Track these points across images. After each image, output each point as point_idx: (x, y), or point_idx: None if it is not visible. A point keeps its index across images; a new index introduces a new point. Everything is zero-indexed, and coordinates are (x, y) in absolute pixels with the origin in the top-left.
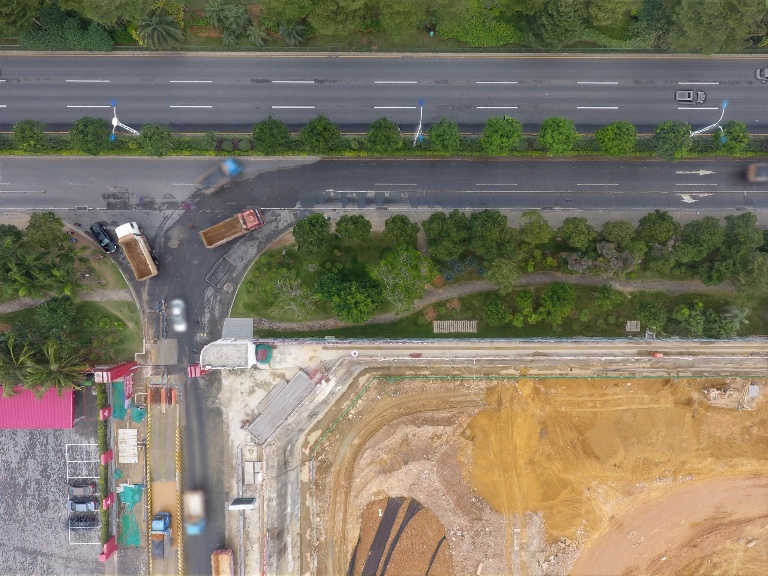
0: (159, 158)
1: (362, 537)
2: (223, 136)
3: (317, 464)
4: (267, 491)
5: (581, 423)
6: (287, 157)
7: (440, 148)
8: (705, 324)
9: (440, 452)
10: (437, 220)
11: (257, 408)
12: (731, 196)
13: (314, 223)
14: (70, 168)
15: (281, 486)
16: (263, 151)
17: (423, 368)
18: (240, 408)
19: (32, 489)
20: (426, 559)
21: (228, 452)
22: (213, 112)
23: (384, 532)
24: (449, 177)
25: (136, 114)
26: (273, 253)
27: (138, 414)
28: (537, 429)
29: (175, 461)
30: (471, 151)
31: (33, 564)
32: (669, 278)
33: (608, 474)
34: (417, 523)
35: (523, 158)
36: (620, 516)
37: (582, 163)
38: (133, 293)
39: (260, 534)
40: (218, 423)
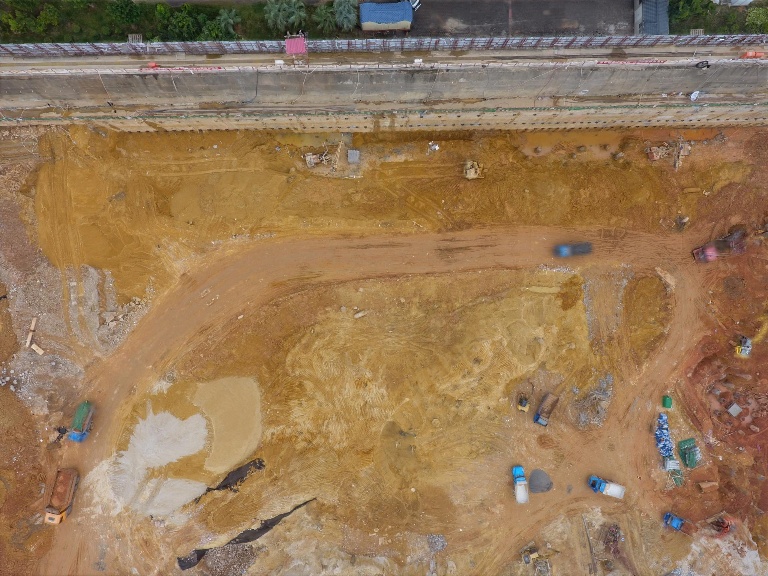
0: None
1: None
2: None
3: None
4: None
5: (166, 187)
6: None
7: None
8: None
9: None
10: None
11: None
12: None
13: None
14: None
15: None
16: None
17: None
18: None
19: None
20: None
21: None
22: None
23: None
24: None
25: None
26: None
27: None
28: (106, 187)
29: None
30: None
31: None
32: None
33: (179, 230)
34: None
35: None
36: (192, 273)
37: None
38: None
39: None
40: None
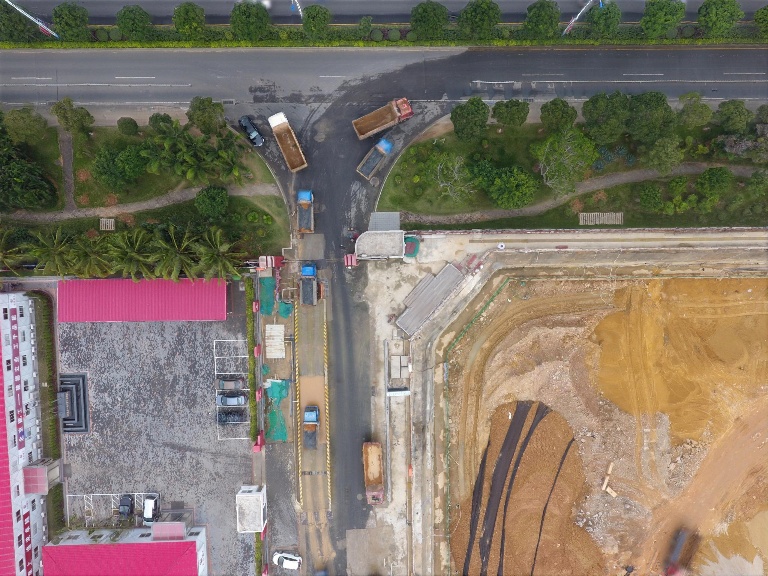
0: (305, 50)
1: (492, 440)
2: (372, 25)
3: (449, 367)
4: (413, 385)
5: (702, 329)
6: (434, 48)
7: (601, 28)
8: None
9: (572, 353)
10: (602, 99)
11: (403, 302)
12: None
13: (476, 105)
14: (216, 61)
15: (424, 382)
16: (422, 33)
17: (556, 269)
18: (386, 303)
19: (181, 385)
20: (556, 460)
21: (374, 347)
22: (359, 2)
23: (514, 434)
24: (596, 67)
25: (282, 5)
26: (420, 145)
27: (285, 310)
28: (662, 333)
29: (323, 355)
30: (620, 39)
31: (182, 459)
32: None
33: (733, 376)
34: (546, 425)
35: (671, 47)
36: (745, 418)
37: (729, 52)
38: (280, 188)
39: (406, 428)
40: (364, 318)
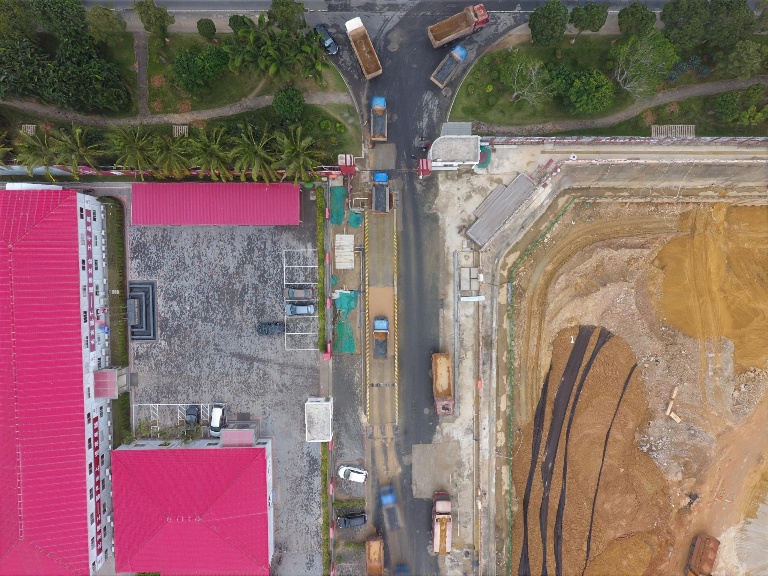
0: None
1: (554, 364)
2: None
3: (512, 288)
4: None
5: (764, 259)
6: None
7: None
8: None
9: (637, 275)
10: None
11: (474, 213)
12: None
13: None
14: None
15: (492, 296)
16: None
17: (622, 189)
18: (457, 214)
19: (249, 294)
20: (619, 385)
21: (444, 258)
22: None
23: (577, 358)
24: None
25: None
26: None
27: (355, 220)
28: (725, 260)
29: (394, 265)
30: None
31: (249, 370)
32: None
33: None
34: (609, 350)
35: None
36: None
37: None
38: (352, 97)
39: (474, 341)
40: (434, 229)
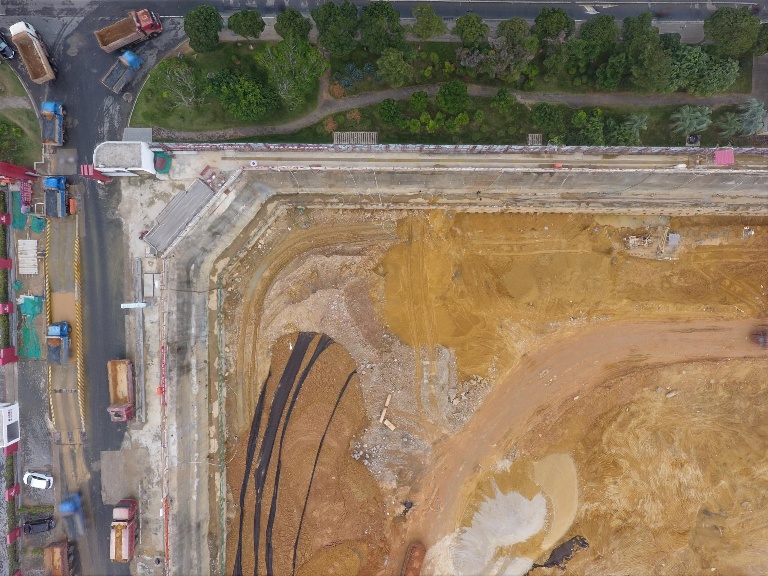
0: None
1: (272, 370)
2: None
3: (226, 294)
4: (167, 304)
5: (498, 267)
6: None
7: None
8: (606, 136)
9: (349, 282)
10: (324, 6)
11: (156, 219)
12: (635, 8)
13: (202, 12)
14: None
15: (183, 302)
16: None
17: (331, 196)
18: (140, 219)
19: None
20: (336, 392)
21: (128, 264)
22: None
23: (294, 365)
24: None
25: None
26: None
27: (38, 225)
28: (450, 267)
29: (74, 271)
30: None
31: None
32: (571, 91)
33: (521, 312)
34: (327, 357)
35: None
36: (532, 354)
37: None
38: (32, 101)
39: (160, 347)
40: (118, 235)
